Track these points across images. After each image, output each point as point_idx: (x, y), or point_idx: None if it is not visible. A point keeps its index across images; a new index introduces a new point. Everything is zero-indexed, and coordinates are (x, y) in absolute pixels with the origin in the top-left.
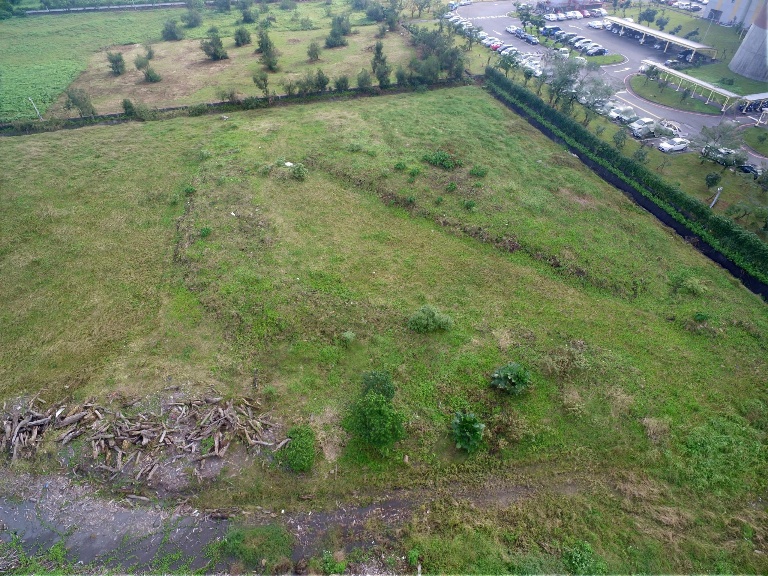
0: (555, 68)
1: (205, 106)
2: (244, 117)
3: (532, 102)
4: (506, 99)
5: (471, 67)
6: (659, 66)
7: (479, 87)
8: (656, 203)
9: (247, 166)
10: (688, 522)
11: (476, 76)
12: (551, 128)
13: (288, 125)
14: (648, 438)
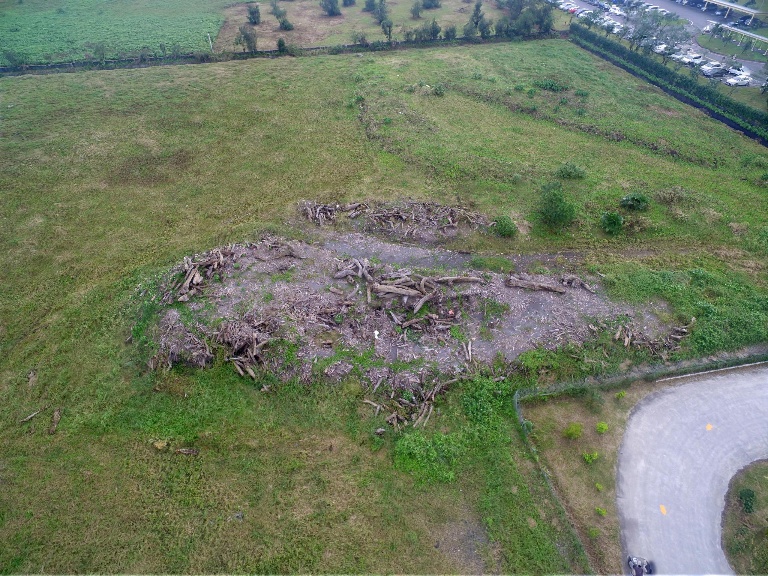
0: (637, 21)
1: (341, 47)
2: (376, 55)
3: (616, 49)
4: (591, 49)
5: (555, 25)
6: (723, 25)
7: (565, 40)
8: (727, 117)
9: (394, 86)
10: (762, 267)
11: (562, 31)
12: (634, 68)
13: (414, 62)
14: (733, 233)
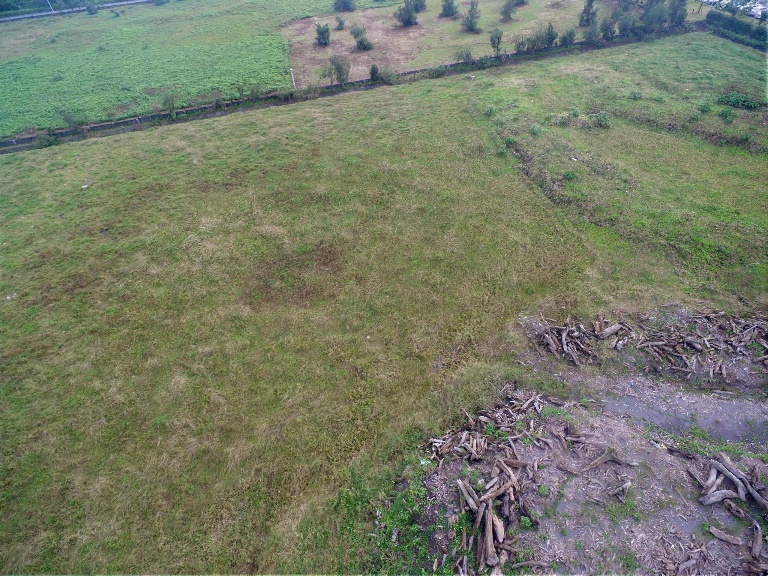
0: None
1: (444, 68)
2: (489, 75)
3: None
4: (746, 42)
5: None
6: None
7: (706, 33)
8: None
9: (538, 118)
10: None
11: (696, 22)
12: None
13: (541, 80)
14: None
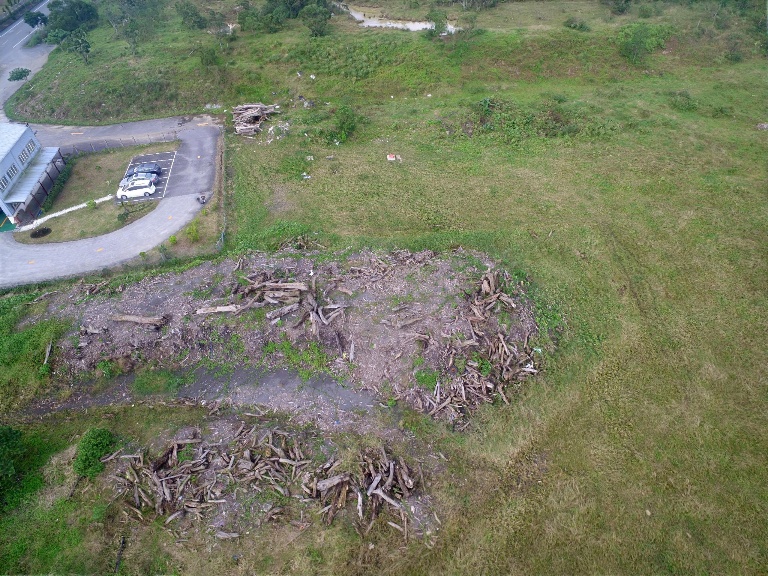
0: None
1: None
2: None
3: None
4: None
5: None
6: None
7: None
8: None
9: None
10: None
11: None
12: None
13: None
14: None
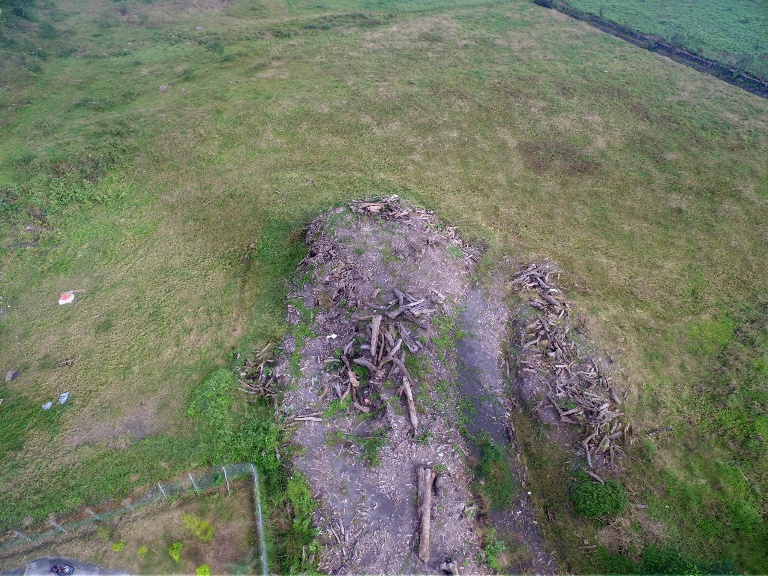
0: None
1: None
2: None
3: None
4: None
5: None
6: None
7: None
8: None
9: None
10: None
11: None
12: None
13: None
14: None
